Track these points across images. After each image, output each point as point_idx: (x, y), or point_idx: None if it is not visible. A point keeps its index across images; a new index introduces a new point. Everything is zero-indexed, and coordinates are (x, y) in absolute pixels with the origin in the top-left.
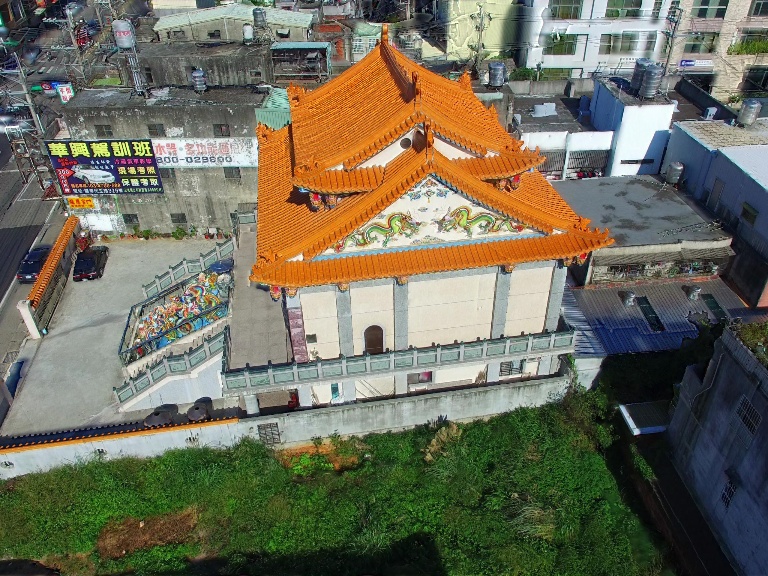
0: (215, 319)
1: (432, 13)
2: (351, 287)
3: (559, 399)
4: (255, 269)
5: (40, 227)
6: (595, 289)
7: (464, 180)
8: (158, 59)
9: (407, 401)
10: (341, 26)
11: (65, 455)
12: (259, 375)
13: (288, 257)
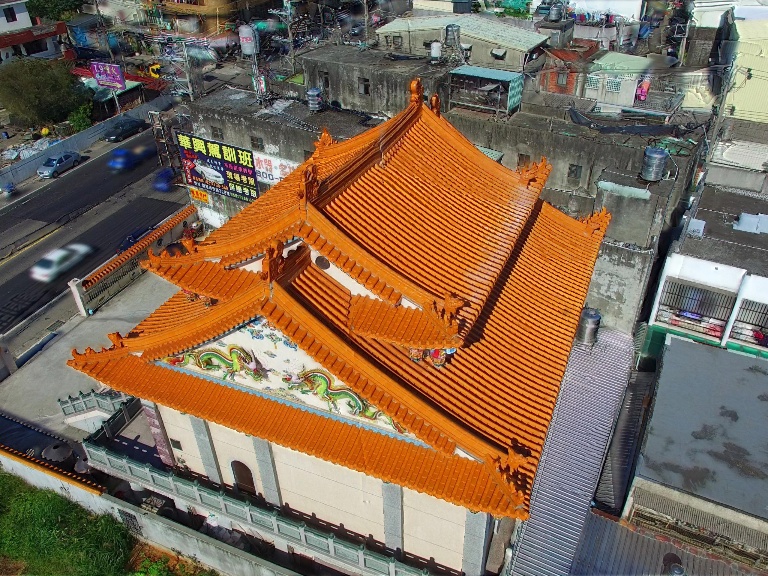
0: None
1: (677, 56)
2: None
3: None
4: (75, 354)
5: (181, 206)
6: (633, 531)
7: (319, 337)
8: (336, 65)
9: (265, 567)
10: (552, 56)
11: None
12: (116, 459)
13: (132, 350)
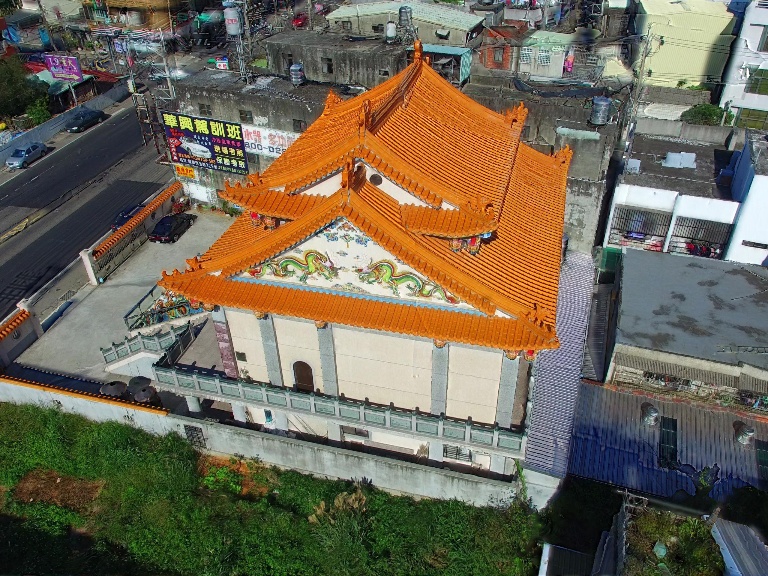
0: (205, 309)
1: (600, 29)
2: (274, 316)
3: (504, 506)
4: (165, 275)
5: (161, 186)
6: (615, 391)
7: (386, 231)
8: (300, 47)
9: (327, 450)
10: (493, 33)
11: (31, 396)
12: (186, 377)
13: (210, 270)
